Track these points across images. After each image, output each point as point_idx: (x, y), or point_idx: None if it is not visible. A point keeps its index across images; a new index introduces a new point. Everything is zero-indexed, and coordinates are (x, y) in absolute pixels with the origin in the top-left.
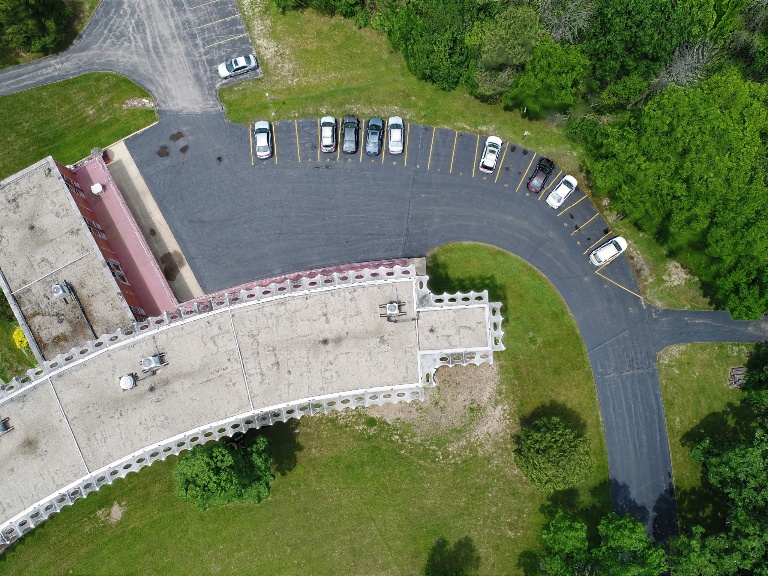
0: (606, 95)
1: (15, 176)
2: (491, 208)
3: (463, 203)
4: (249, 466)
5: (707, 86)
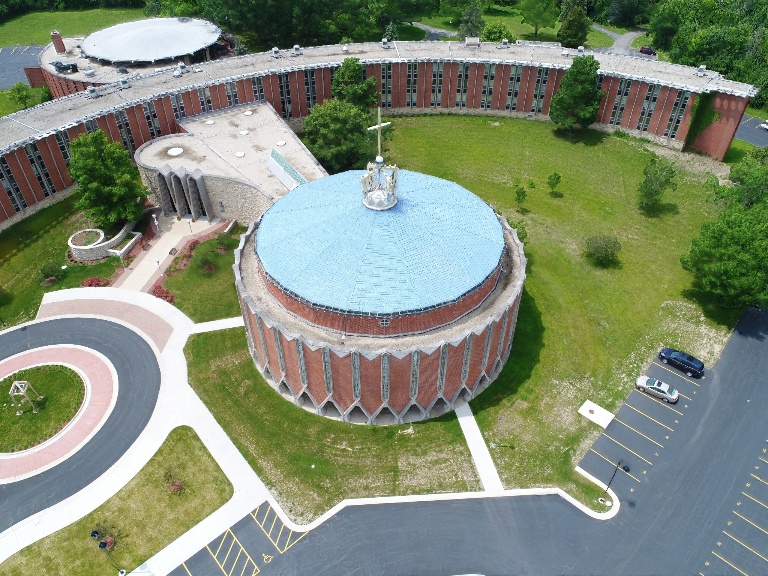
0: None
1: (543, 42)
2: (760, 137)
3: (744, 131)
4: (593, 95)
5: None
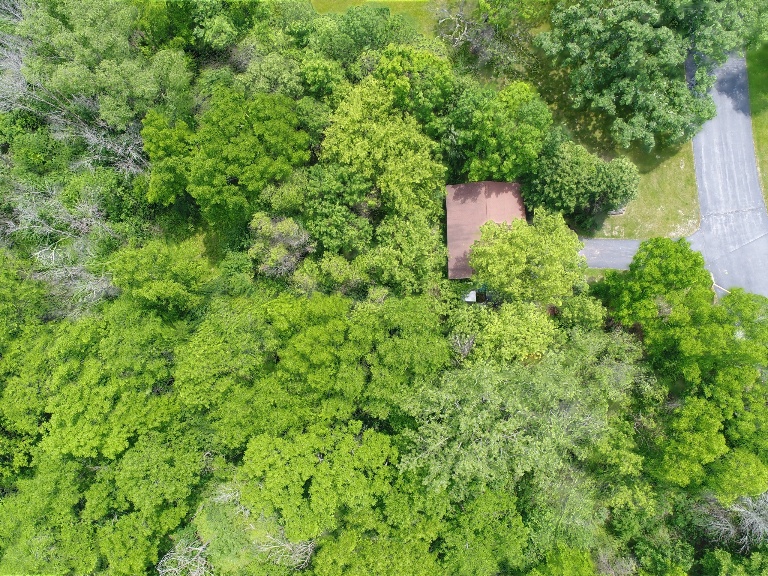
0: None
1: None
2: None
3: None
4: None
5: (766, 482)
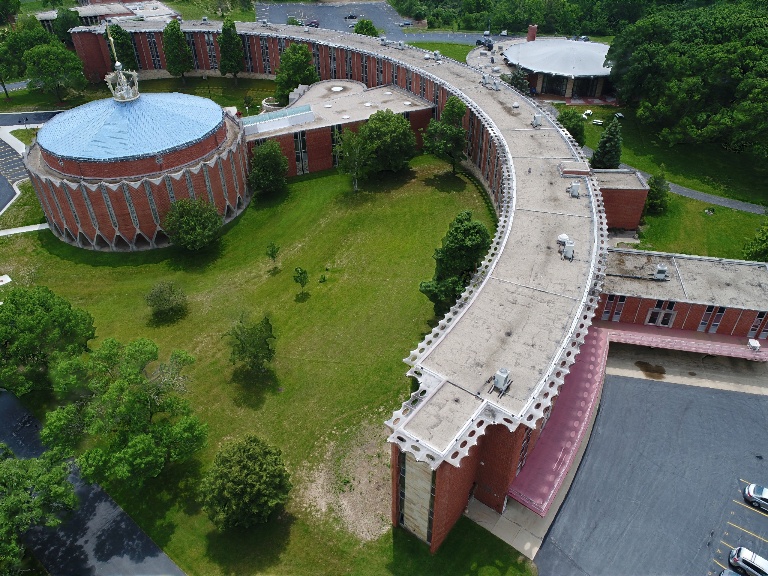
0: None
1: None
2: None
3: None
4: None
5: None
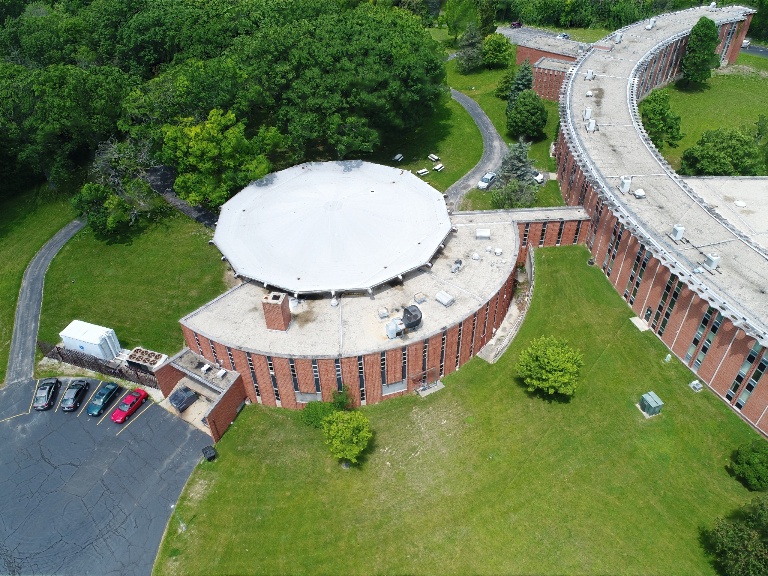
0: (704, 4)
1: (530, 38)
2: None
3: None
4: None
5: None
